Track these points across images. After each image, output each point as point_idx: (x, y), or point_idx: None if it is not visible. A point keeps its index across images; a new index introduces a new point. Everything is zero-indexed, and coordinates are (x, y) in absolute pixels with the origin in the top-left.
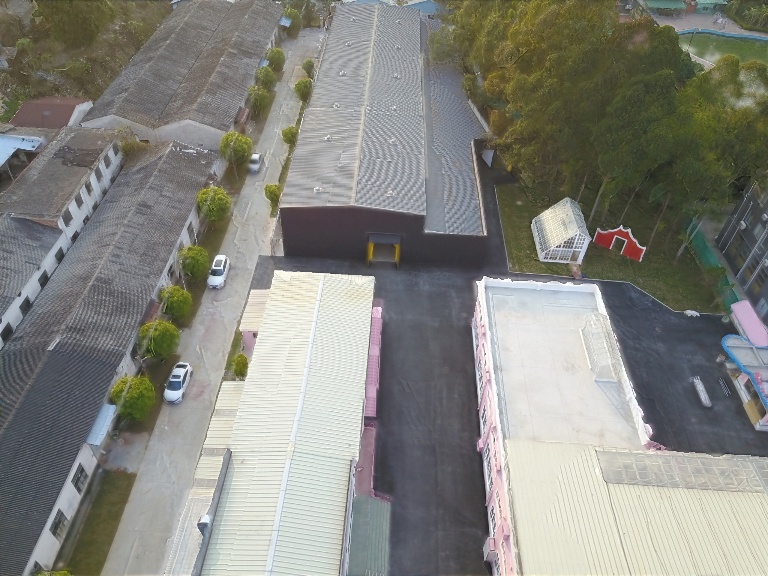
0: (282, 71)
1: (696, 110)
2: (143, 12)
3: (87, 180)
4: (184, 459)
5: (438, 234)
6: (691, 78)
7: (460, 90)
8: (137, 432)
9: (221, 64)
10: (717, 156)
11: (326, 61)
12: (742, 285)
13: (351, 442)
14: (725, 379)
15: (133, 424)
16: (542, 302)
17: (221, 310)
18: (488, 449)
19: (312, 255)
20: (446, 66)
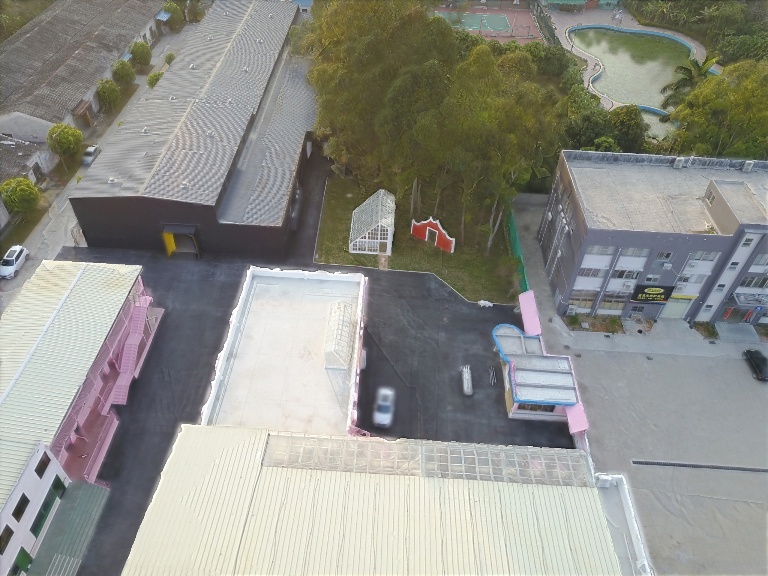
0: (152, 65)
1: (458, 100)
2: (24, 6)
3: None
4: None
5: (232, 225)
6: None
7: None
8: None
9: (73, 57)
10: None
11: (181, 54)
12: (548, 276)
13: (48, 427)
14: (496, 368)
15: None
16: (304, 291)
17: (4, 300)
18: None
19: (115, 246)
20: (309, 60)
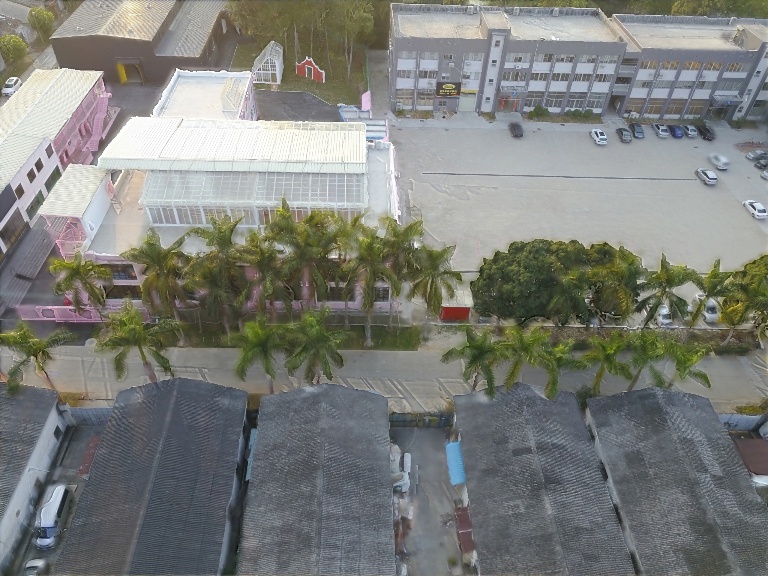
0: None
1: None
2: None
3: None
4: None
5: (165, 57)
6: None
7: None
8: None
9: None
10: None
11: None
12: None
13: (51, 133)
14: None
15: None
16: (212, 82)
17: None
18: None
19: None
20: None
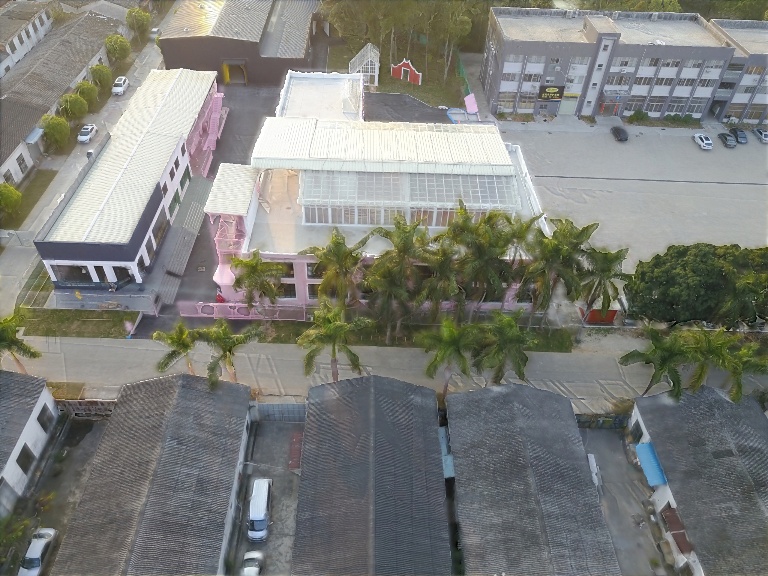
0: None
1: None
2: None
3: (26, 28)
4: None
5: (270, 58)
6: None
7: None
8: (60, 155)
9: None
10: None
11: None
12: (485, 96)
13: (184, 132)
14: None
15: (57, 151)
16: (325, 83)
17: (120, 105)
18: None
19: None
20: None
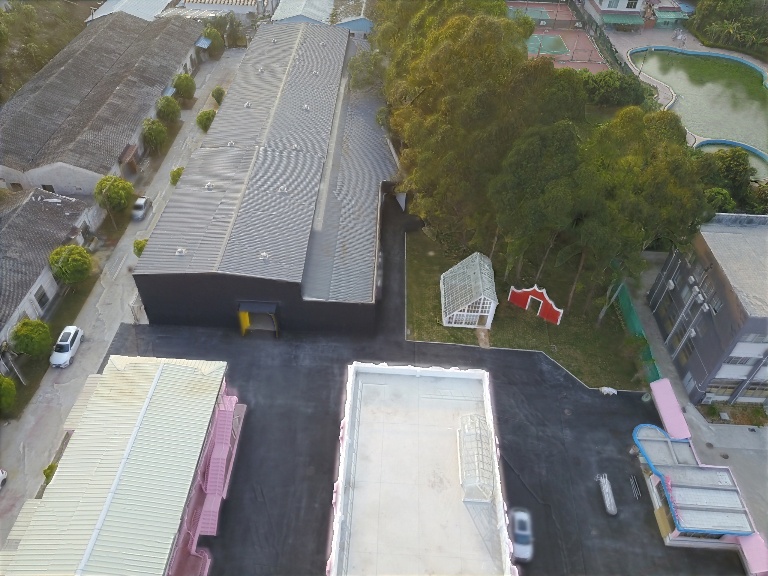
0: (195, 98)
1: (598, 168)
2: (51, 32)
3: None
4: None
5: (318, 302)
6: (640, 103)
7: None
8: None
9: (115, 94)
10: (629, 217)
11: (233, 90)
12: (670, 353)
13: None
14: (637, 476)
15: None
16: (419, 393)
17: (60, 395)
18: None
19: (181, 323)
20: (369, 93)
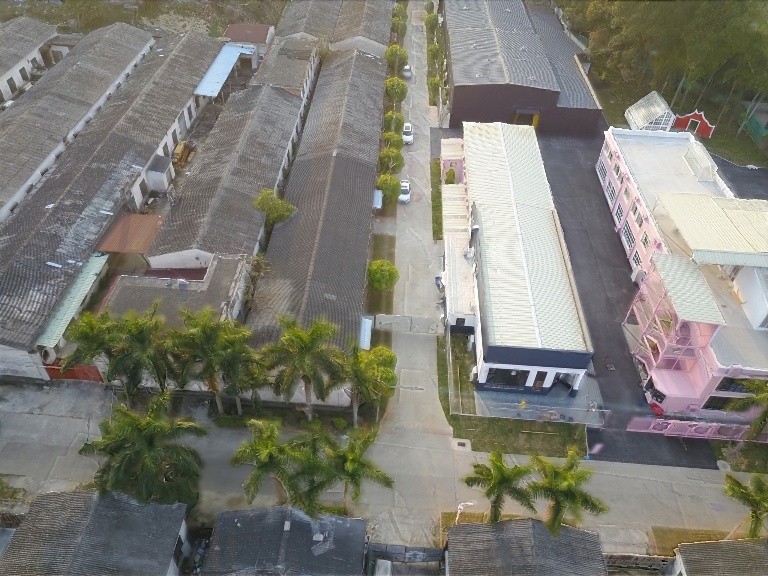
0: None
1: (762, 9)
2: None
3: None
4: (423, 230)
5: (567, 108)
6: None
7: (555, 24)
8: (386, 216)
9: (368, 1)
10: None
11: (449, 1)
12: None
13: (548, 203)
14: None
15: (383, 212)
16: (653, 142)
17: (416, 156)
18: (626, 226)
19: None
20: (540, 8)
